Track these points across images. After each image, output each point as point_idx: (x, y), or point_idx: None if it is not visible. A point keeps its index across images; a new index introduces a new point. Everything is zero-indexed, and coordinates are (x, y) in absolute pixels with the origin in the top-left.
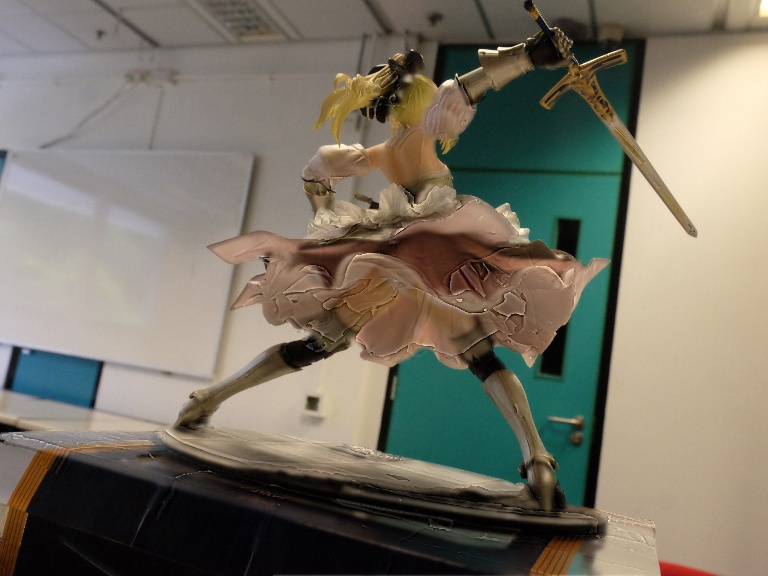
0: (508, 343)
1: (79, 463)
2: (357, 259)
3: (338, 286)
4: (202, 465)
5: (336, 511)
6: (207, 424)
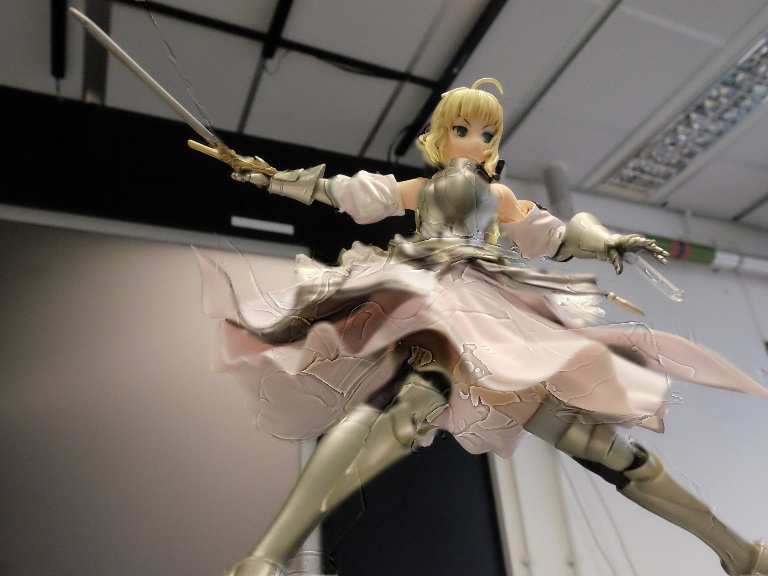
0: (437, 322)
1: None
2: None
3: None
4: None
5: None
6: None
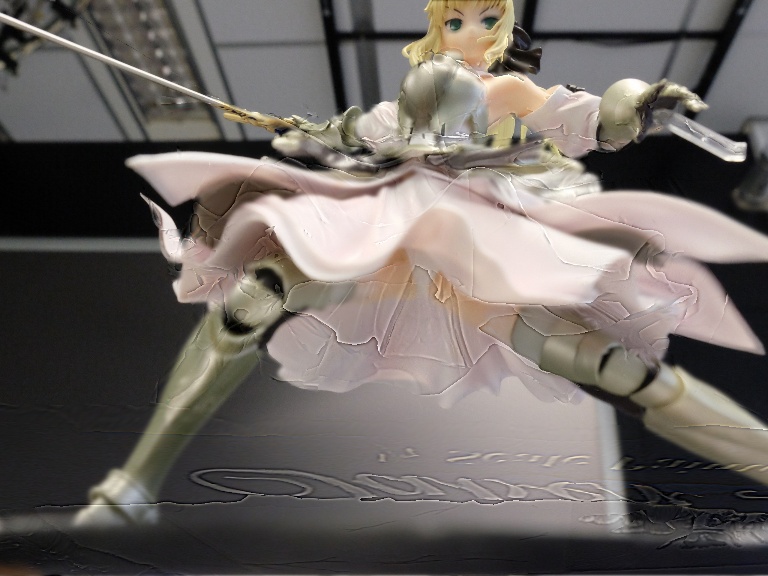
0: (252, 211)
1: None
2: None
3: (429, 409)
4: None
5: None
6: None
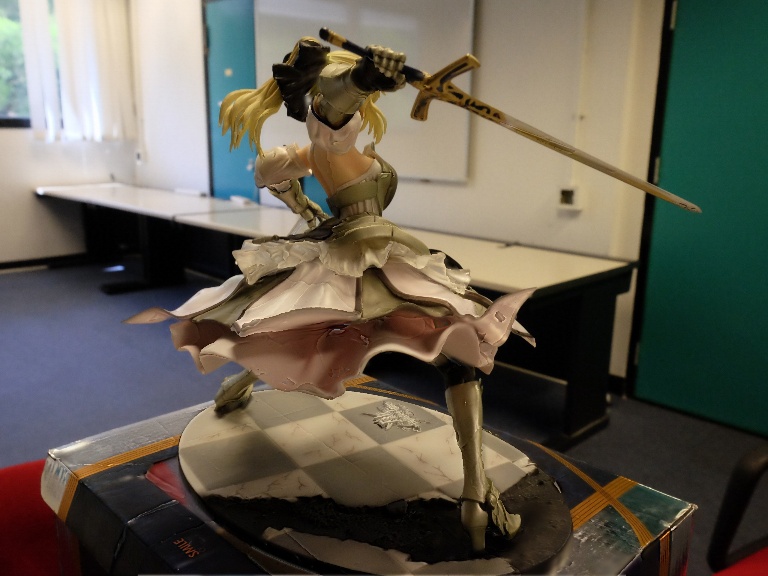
0: None
1: (82, 493)
2: (202, 354)
3: None
4: (183, 484)
5: (227, 575)
6: (240, 404)
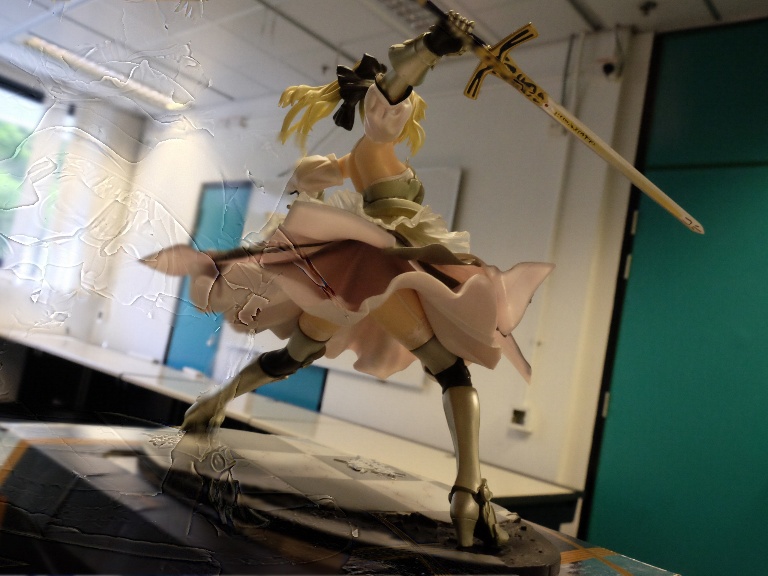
0: None
1: None
2: None
3: None
4: None
5: None
6: None
